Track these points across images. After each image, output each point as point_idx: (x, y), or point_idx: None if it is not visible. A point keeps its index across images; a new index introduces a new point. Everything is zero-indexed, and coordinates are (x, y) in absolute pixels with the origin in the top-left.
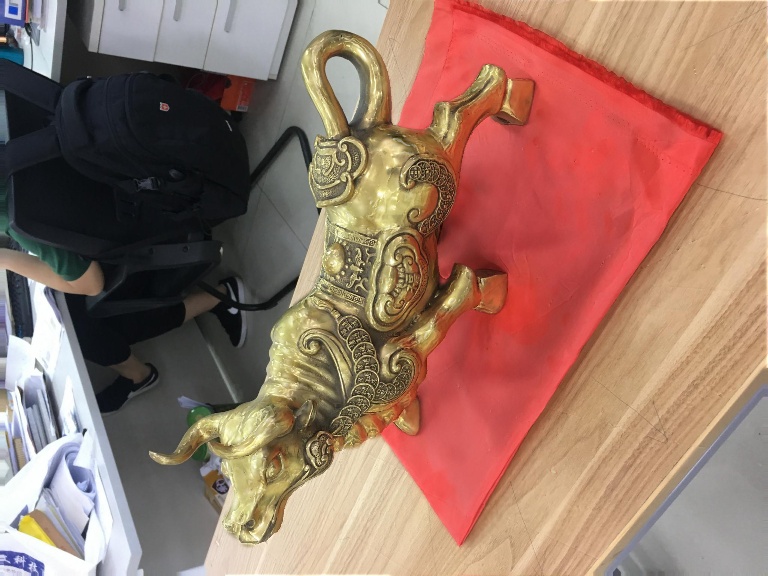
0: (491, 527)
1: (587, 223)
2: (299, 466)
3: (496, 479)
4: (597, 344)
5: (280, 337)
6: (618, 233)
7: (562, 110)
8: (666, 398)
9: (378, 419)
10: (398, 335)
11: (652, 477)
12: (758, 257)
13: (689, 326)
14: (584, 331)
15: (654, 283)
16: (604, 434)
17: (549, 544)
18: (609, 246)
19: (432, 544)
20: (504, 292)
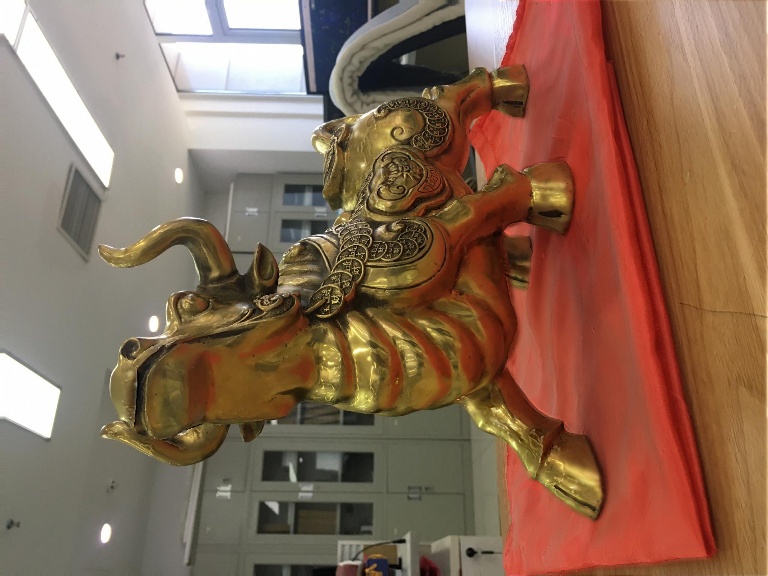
0: (716, 425)
1: (570, 21)
2: None
3: (650, 316)
4: (620, 28)
5: None
6: None
7: (534, 36)
8: None
9: (411, 324)
10: None
11: None
12: None
13: None
14: (581, 23)
15: None
16: (675, 36)
17: (763, 257)
18: None
19: None
20: (566, 171)
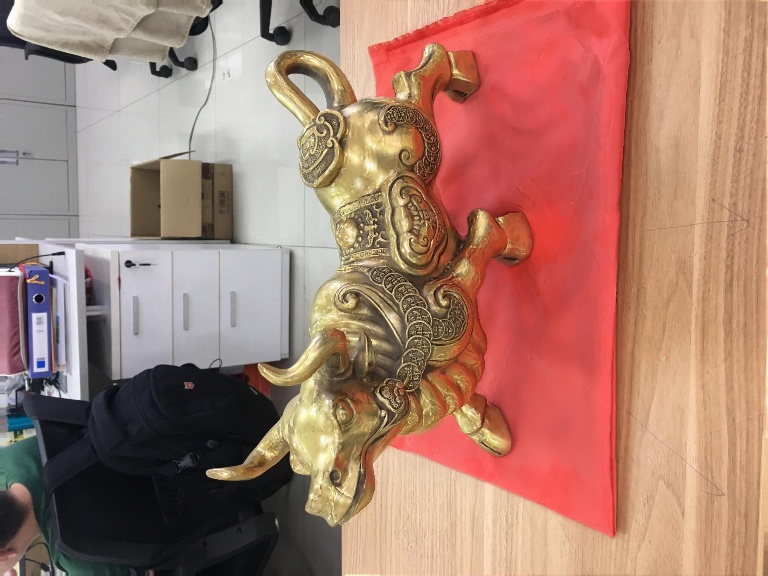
0: (635, 484)
1: (567, 110)
2: (374, 412)
3: (611, 414)
4: (632, 197)
5: (316, 312)
6: (594, 87)
7: (503, 51)
8: (722, 185)
9: (450, 381)
10: (436, 279)
11: (758, 271)
12: (718, 5)
13: (700, 107)
14: (611, 183)
15: (649, 103)
16: (688, 273)
17: (704, 445)
18: (593, 103)
19: (585, 569)
20: (527, 228)
